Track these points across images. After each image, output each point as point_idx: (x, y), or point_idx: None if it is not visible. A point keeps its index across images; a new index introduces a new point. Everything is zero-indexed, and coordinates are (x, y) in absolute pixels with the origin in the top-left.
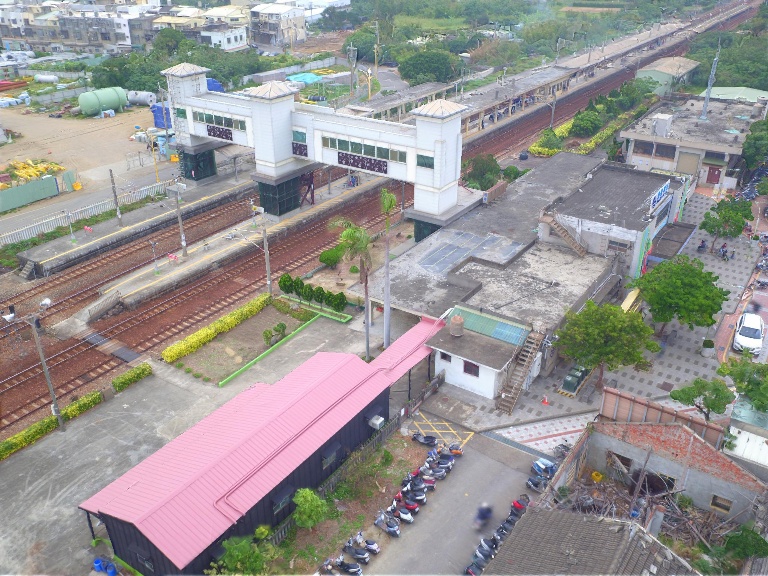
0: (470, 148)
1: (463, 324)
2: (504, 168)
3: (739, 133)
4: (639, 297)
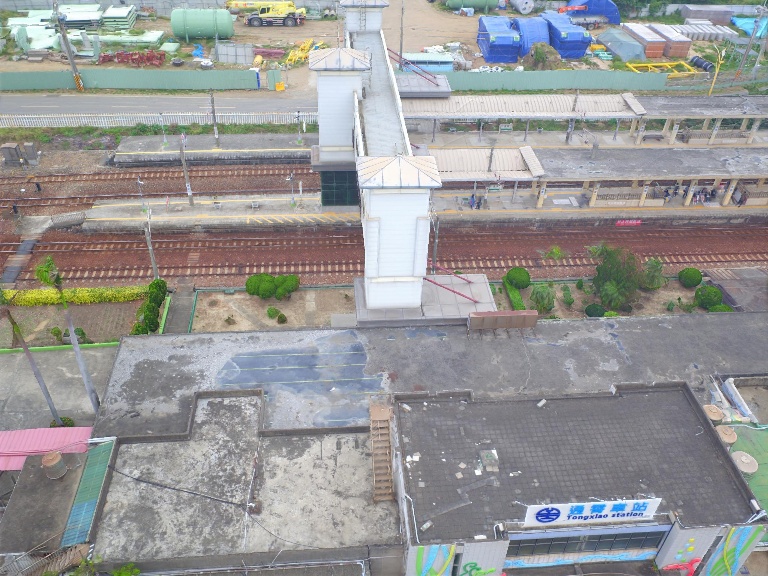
0: (754, 224)
1: (53, 468)
2: (726, 283)
3: None
4: None
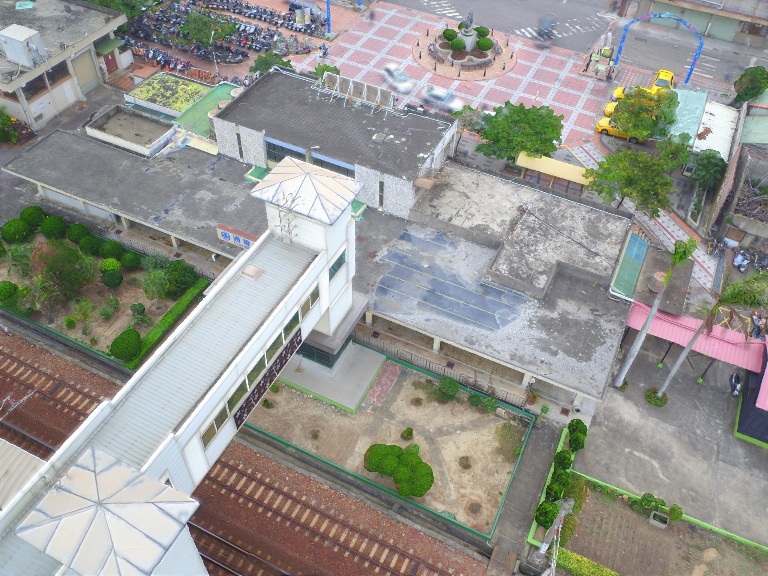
0: None
1: None
2: None
3: (36, 3)
4: None
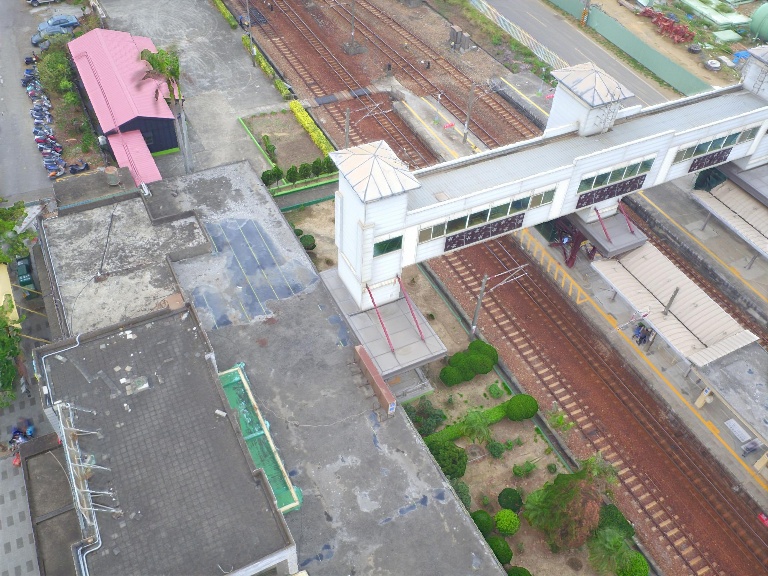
0: None
1: None
2: None
3: None
4: None
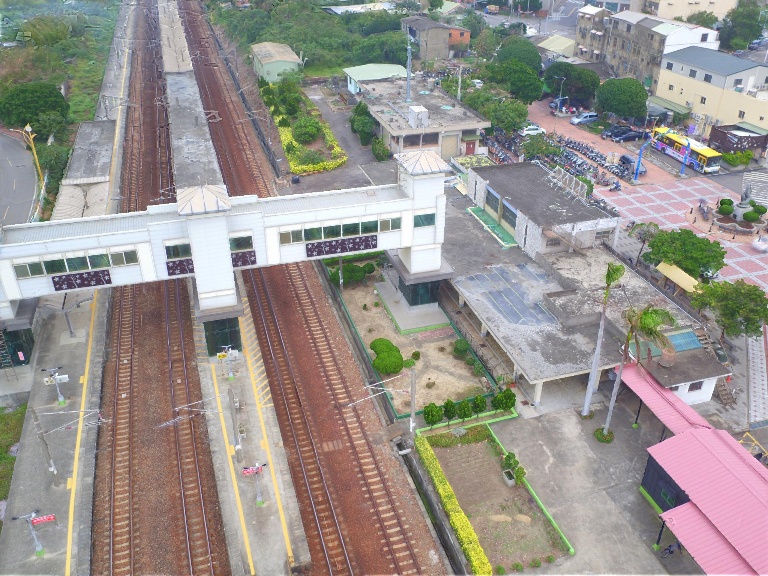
0: None
1: None
2: None
3: (454, 108)
4: (680, 268)
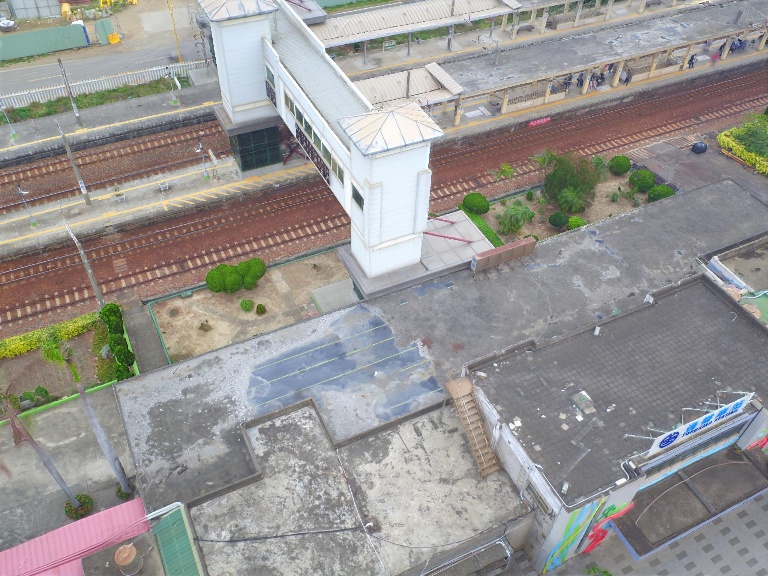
0: (642, 100)
1: (132, 565)
2: (647, 163)
3: None
4: None
